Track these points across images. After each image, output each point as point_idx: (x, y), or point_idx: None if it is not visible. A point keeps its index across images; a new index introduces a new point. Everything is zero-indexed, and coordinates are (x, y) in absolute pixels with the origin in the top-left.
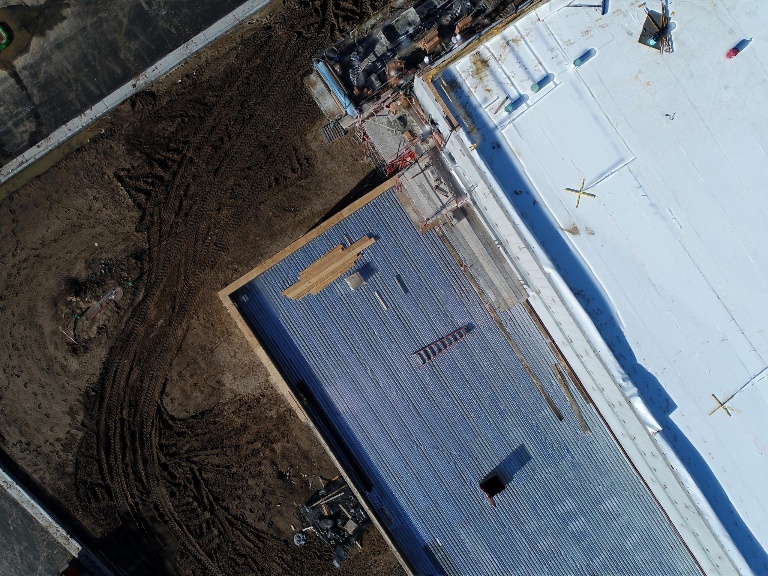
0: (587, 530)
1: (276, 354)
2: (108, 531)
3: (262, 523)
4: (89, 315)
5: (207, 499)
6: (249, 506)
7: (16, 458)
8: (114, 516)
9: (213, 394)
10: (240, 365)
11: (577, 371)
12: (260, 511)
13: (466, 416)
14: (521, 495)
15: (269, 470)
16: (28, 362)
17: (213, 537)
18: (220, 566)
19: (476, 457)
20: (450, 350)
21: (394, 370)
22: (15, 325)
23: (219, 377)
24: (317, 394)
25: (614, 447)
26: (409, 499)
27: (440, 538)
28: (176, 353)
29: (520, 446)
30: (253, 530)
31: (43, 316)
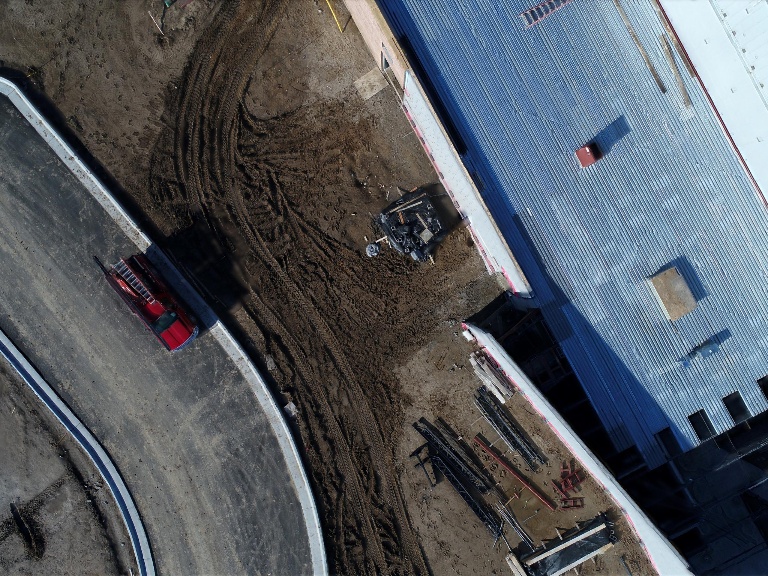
0: (681, 209)
1: (380, 7)
2: (178, 230)
3: (335, 231)
4: (179, 5)
5: (281, 204)
6: (324, 213)
7: (92, 149)
8: (186, 215)
9: (296, 97)
10: (326, 68)
11: (687, 35)
12: (334, 219)
13: (568, 83)
14: (617, 169)
15: (347, 178)
16: (112, 52)
17: (285, 242)
18: (289, 273)
19: (574, 126)
20: (557, 13)
21: (499, 31)
22: (102, 14)
23: (304, 79)
24: (418, 51)
25: (716, 124)
26: (503, 166)
27: (531, 208)
28: (263, 52)
29: (620, 117)
30: (326, 238)
31: (131, 6)
